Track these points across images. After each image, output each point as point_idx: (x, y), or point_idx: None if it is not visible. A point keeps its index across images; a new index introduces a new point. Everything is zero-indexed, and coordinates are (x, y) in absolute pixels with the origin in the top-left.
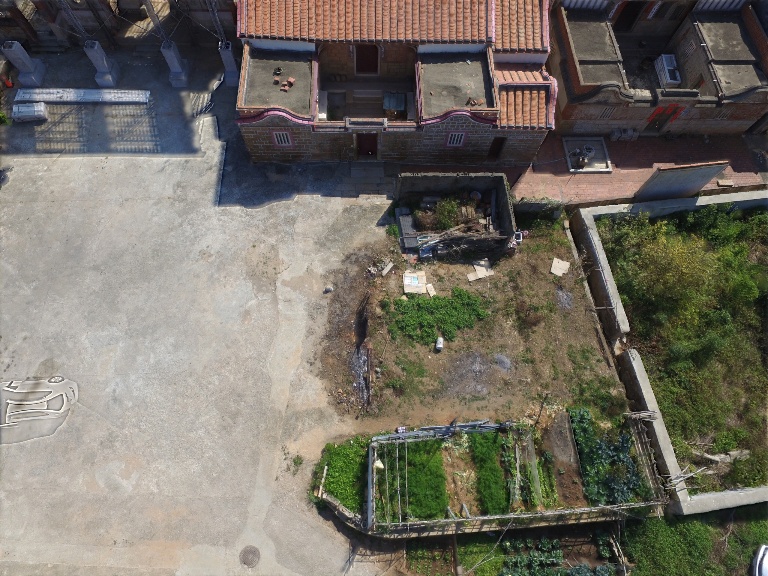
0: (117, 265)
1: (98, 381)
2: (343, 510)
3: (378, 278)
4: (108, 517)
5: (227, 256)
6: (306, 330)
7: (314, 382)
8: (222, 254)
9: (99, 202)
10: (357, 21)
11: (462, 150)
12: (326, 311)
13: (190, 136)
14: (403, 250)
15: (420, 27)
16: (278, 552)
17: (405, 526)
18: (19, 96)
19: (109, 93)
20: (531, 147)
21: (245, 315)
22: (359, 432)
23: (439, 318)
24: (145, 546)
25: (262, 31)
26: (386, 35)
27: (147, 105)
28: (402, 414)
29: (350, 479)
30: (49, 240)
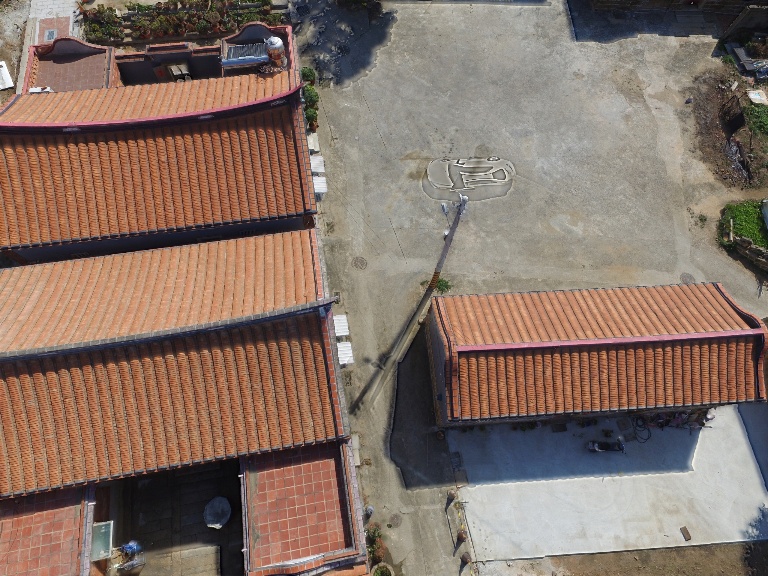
0: (511, 81)
1: (527, 160)
2: (757, 247)
3: (729, 92)
4: (571, 250)
5: (597, 77)
6: (681, 128)
7: (699, 165)
8: (592, 75)
9: (478, 36)
10: None
11: None
12: (692, 116)
13: None
14: (741, 74)
15: None
16: (707, 278)
17: None
18: None
19: None
20: None
21: (627, 118)
22: (747, 199)
23: None
24: (608, 269)
25: None
26: None
27: None
28: None
29: (756, 226)
30: (448, 63)
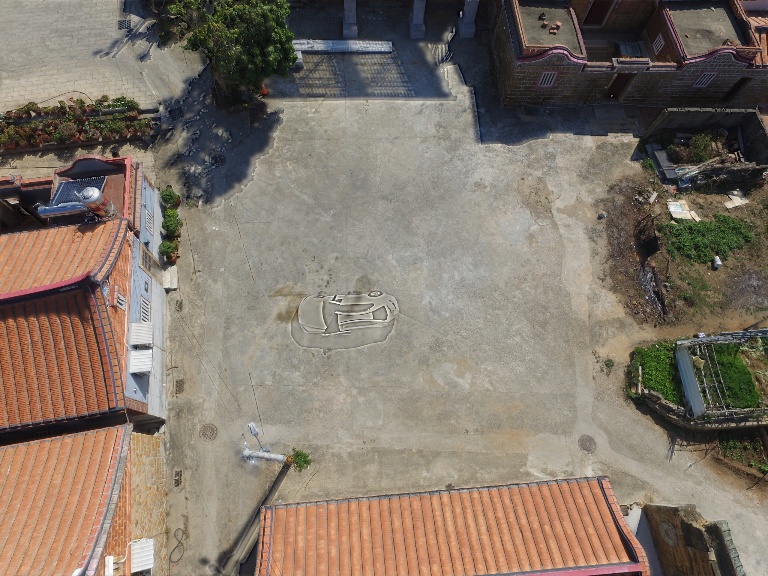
0: (403, 195)
1: (413, 295)
2: (667, 403)
3: (646, 205)
4: (455, 410)
5: (501, 187)
6: (591, 251)
7: (609, 296)
8: (496, 185)
9: (371, 140)
10: None
11: (703, 92)
12: (604, 234)
13: (438, 82)
14: (662, 181)
15: None
16: (610, 441)
17: (726, 416)
18: None
19: (355, 44)
20: (767, 88)
21: (531, 238)
22: (660, 338)
23: (712, 240)
24: (495, 434)
25: None
26: None
27: (391, 55)
28: (697, 322)
29: (667, 377)
30: (335, 173)
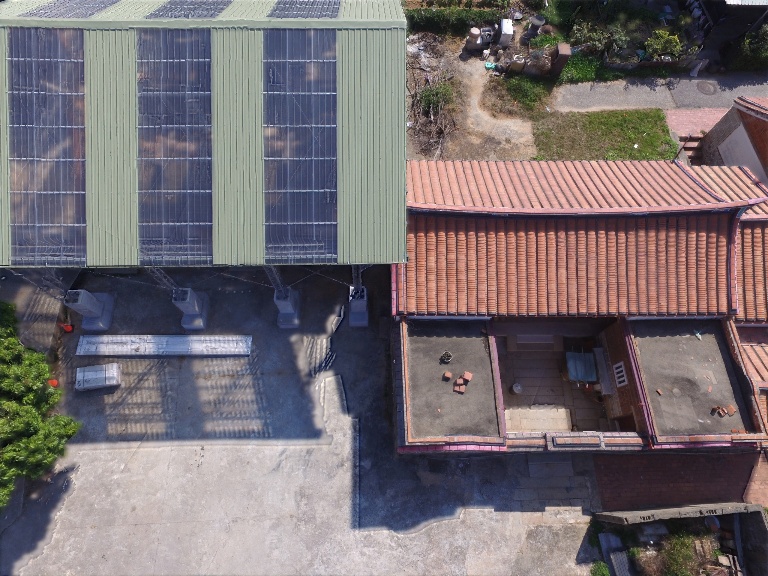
0: None
1: None
2: None
3: None
4: None
5: None
6: None
7: None
8: None
9: (198, 525)
10: (553, 288)
11: None
12: None
13: (310, 409)
14: None
15: (638, 295)
16: None
17: None
18: (82, 348)
19: (199, 341)
20: None
21: None
22: None
23: None
24: None
25: (426, 305)
26: (593, 307)
27: (249, 358)
28: None
29: None
30: None
